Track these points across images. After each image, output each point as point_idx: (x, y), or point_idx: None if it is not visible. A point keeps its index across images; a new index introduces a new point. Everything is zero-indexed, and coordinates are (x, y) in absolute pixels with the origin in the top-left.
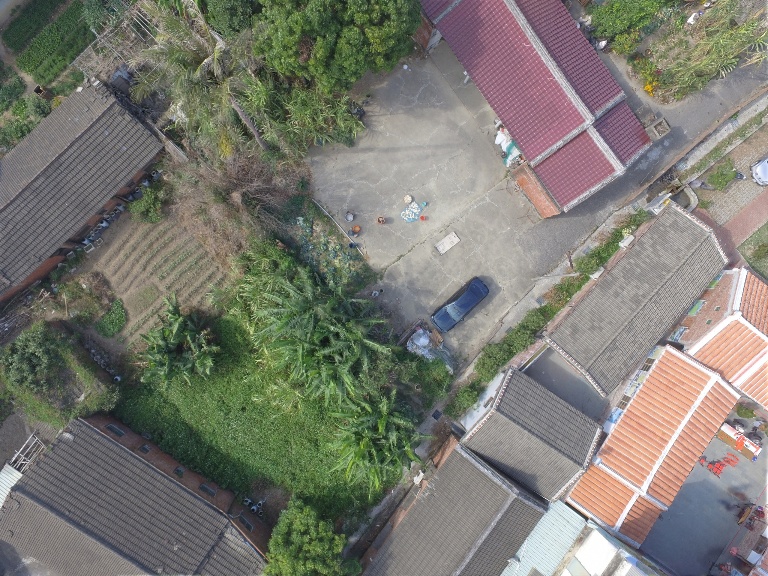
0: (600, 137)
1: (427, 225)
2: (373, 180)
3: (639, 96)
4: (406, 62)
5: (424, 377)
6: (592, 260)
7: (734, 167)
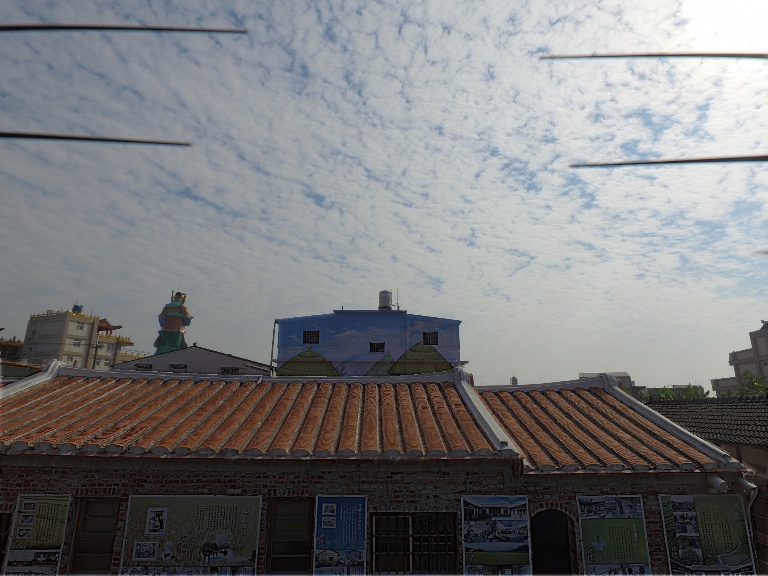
0: None
1: None
2: None
3: None
4: None
5: None
6: None
7: None
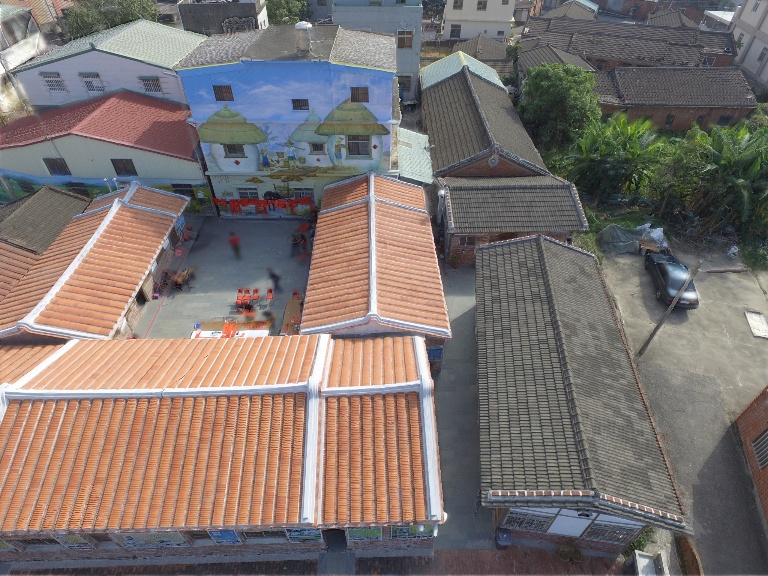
0: None
1: None
2: None
3: None
4: None
5: None
6: None
7: None
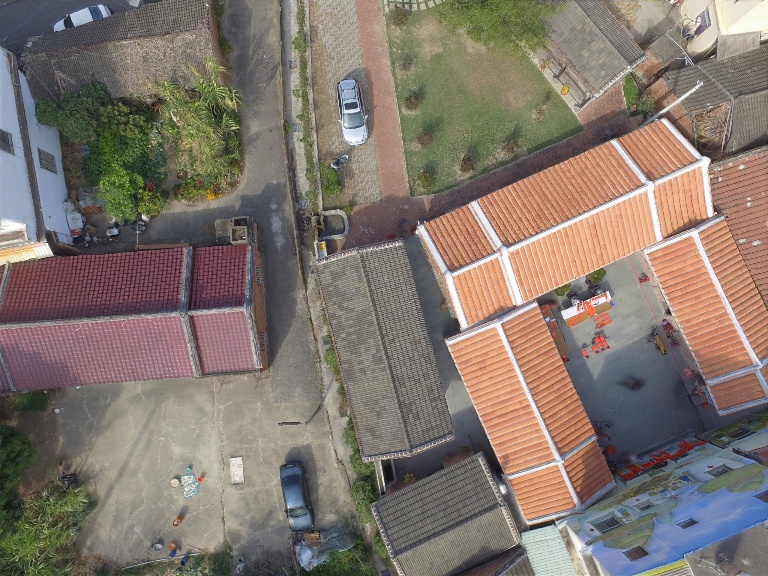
0: (203, 312)
1: (210, 477)
2: (139, 503)
3: (215, 207)
4: (53, 408)
5: (342, 569)
6: (329, 354)
7: (335, 154)
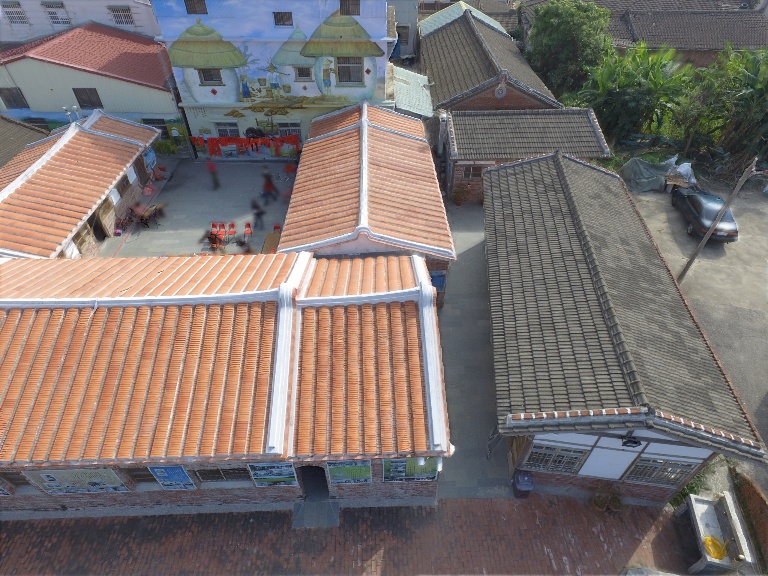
0: None
1: None
2: None
3: None
4: None
5: None
6: None
7: None
